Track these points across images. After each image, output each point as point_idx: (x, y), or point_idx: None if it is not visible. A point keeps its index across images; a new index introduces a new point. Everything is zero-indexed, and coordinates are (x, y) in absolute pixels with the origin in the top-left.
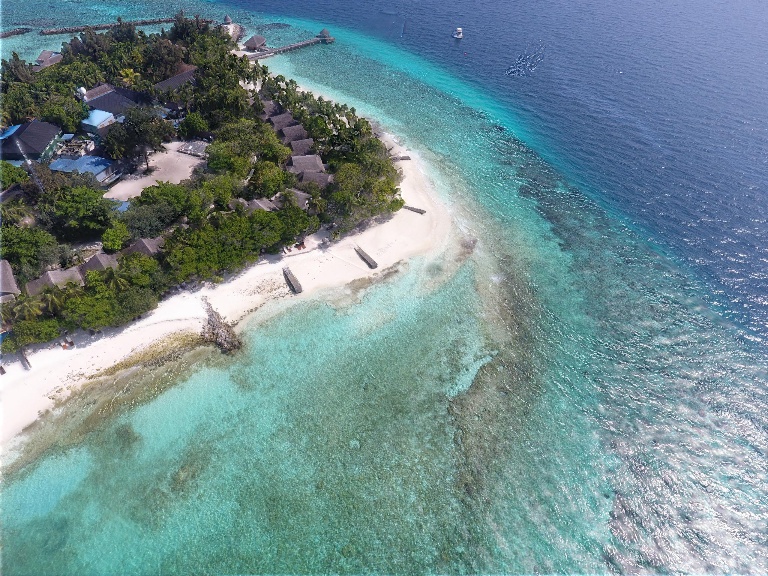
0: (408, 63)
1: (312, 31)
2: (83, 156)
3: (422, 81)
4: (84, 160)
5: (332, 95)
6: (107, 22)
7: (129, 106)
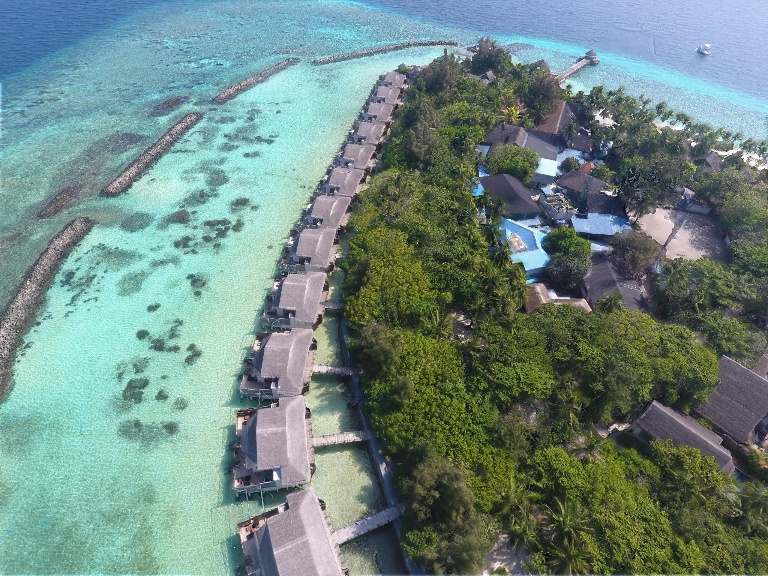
0: (694, 84)
1: (560, 51)
2: (589, 214)
3: (736, 105)
4: (601, 219)
5: (679, 125)
6: (358, 48)
7: (554, 151)
